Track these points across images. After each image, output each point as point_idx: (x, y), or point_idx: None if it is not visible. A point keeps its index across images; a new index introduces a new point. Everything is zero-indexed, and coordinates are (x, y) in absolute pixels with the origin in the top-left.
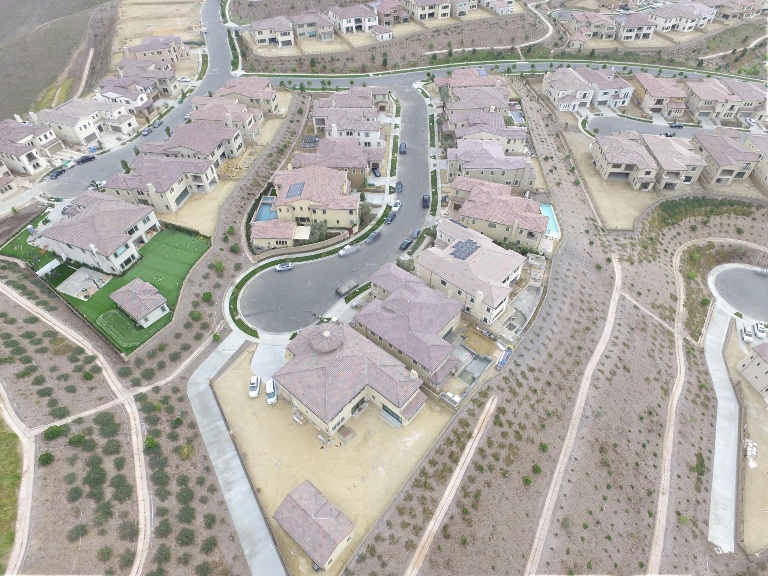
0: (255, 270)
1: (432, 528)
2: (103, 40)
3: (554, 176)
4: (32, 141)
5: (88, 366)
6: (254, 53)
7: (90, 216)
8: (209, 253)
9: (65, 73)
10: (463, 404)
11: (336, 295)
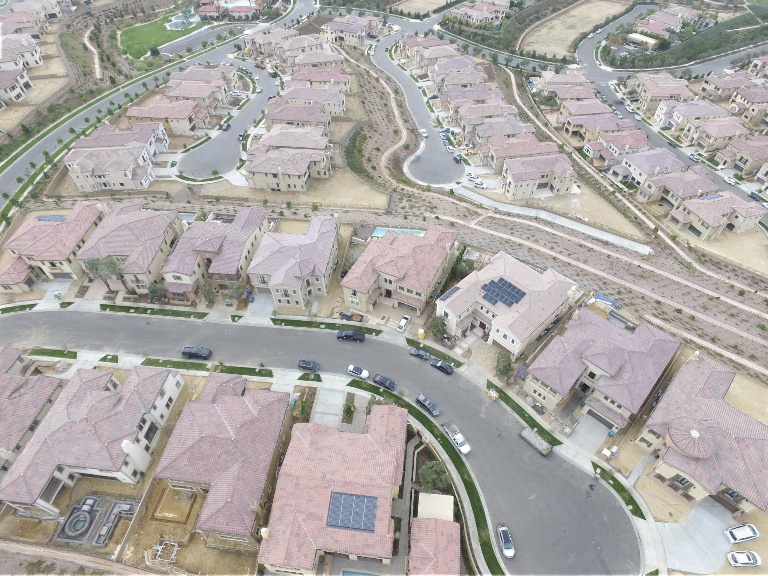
0: None
1: None
2: None
3: None
4: None
5: None
6: None
7: None
8: None
9: None
10: None
11: (550, 457)
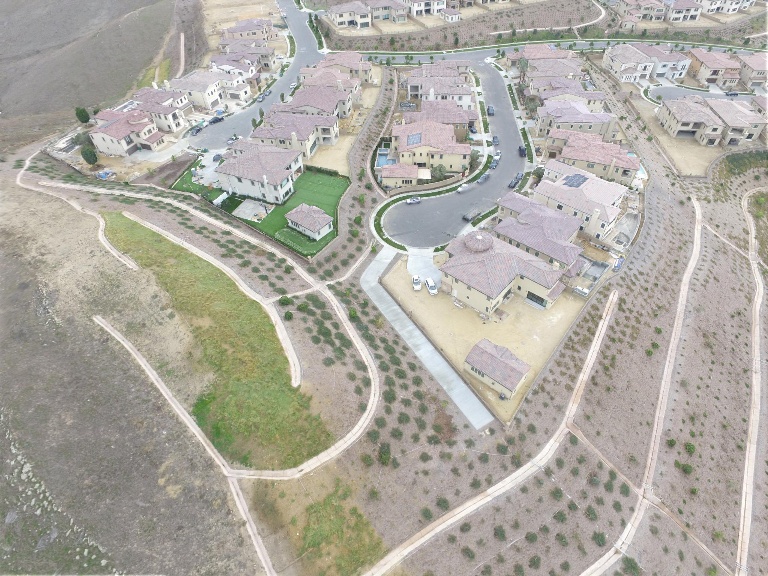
0: (389, 203)
1: (582, 378)
2: (192, 25)
3: (631, 132)
4: (172, 104)
5: (283, 265)
6: (337, 33)
7: (255, 155)
8: (351, 188)
9: (160, 55)
10: (592, 294)
11: (463, 221)
